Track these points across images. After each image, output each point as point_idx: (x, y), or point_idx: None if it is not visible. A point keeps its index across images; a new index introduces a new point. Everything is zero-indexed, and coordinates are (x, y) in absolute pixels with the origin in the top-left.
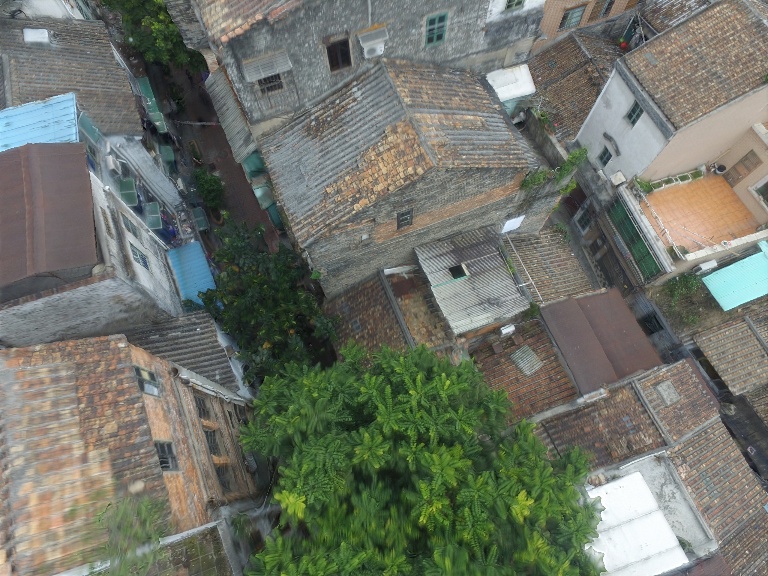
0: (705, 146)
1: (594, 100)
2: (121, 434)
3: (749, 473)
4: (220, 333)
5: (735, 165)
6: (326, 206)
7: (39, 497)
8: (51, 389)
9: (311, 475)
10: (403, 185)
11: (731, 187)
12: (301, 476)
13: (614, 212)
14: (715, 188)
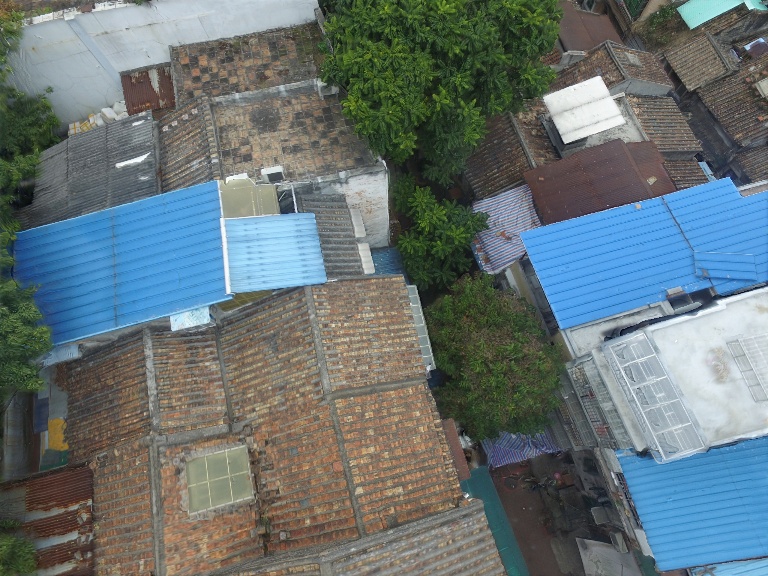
0: None
1: None
2: None
3: (690, 133)
4: None
5: None
6: None
7: None
8: None
9: None
10: None
11: None
12: None
13: None
14: None
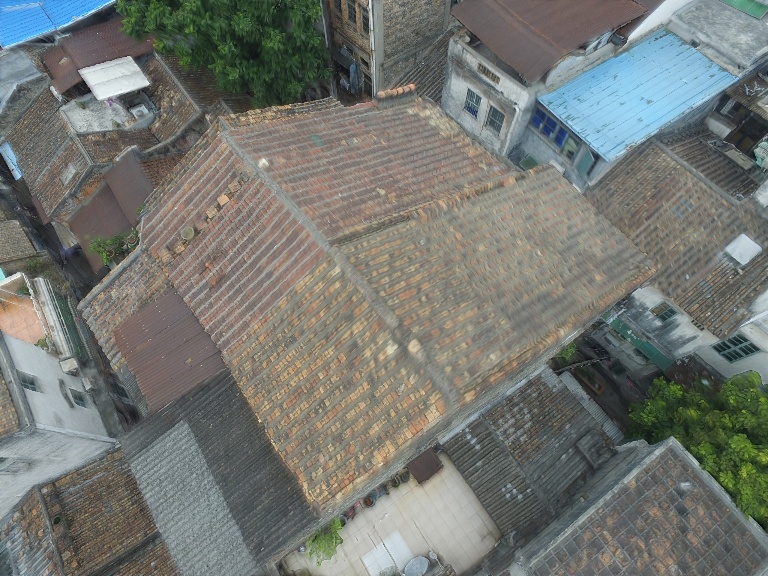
0: None
1: (78, 513)
2: None
3: (25, 170)
4: None
5: None
6: None
7: None
8: None
9: None
10: None
11: None
12: None
13: None
14: None
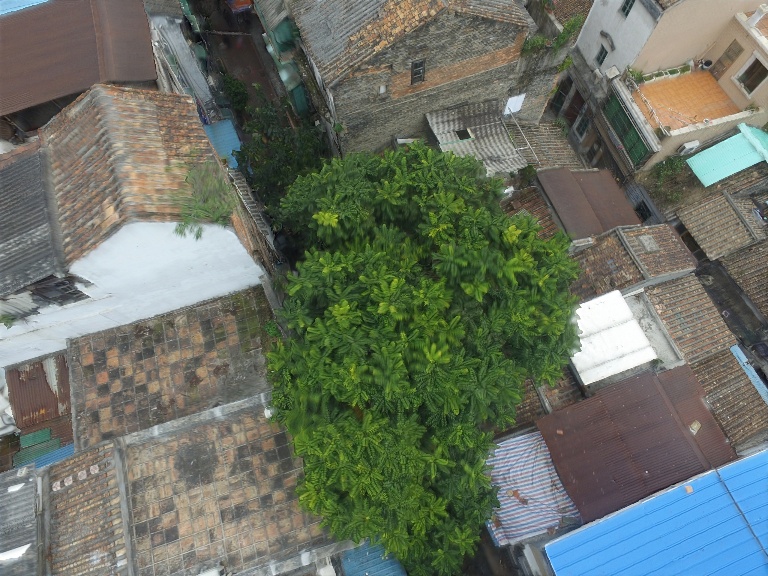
0: (692, 35)
1: None
2: (193, 156)
3: (720, 321)
4: (250, 192)
5: (720, 58)
6: (350, 52)
7: (137, 176)
8: (139, 116)
9: (342, 202)
10: (418, 26)
11: (716, 80)
12: (334, 204)
13: (609, 108)
14: (702, 81)
